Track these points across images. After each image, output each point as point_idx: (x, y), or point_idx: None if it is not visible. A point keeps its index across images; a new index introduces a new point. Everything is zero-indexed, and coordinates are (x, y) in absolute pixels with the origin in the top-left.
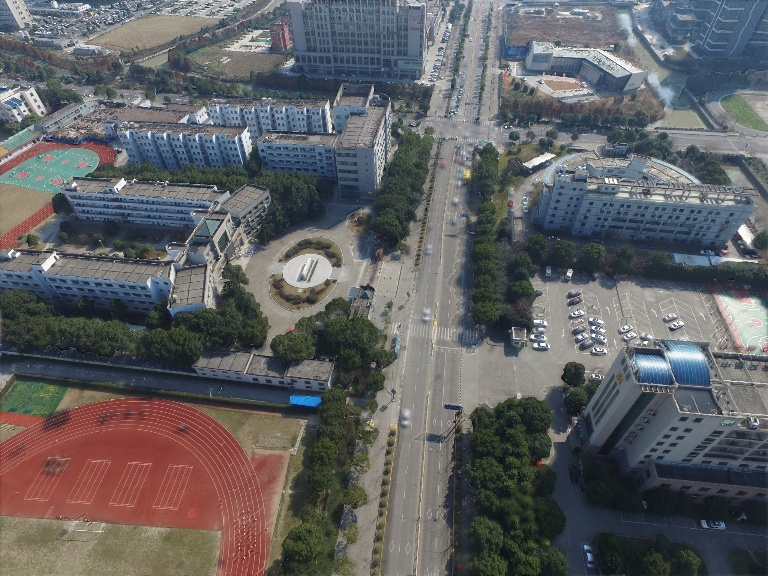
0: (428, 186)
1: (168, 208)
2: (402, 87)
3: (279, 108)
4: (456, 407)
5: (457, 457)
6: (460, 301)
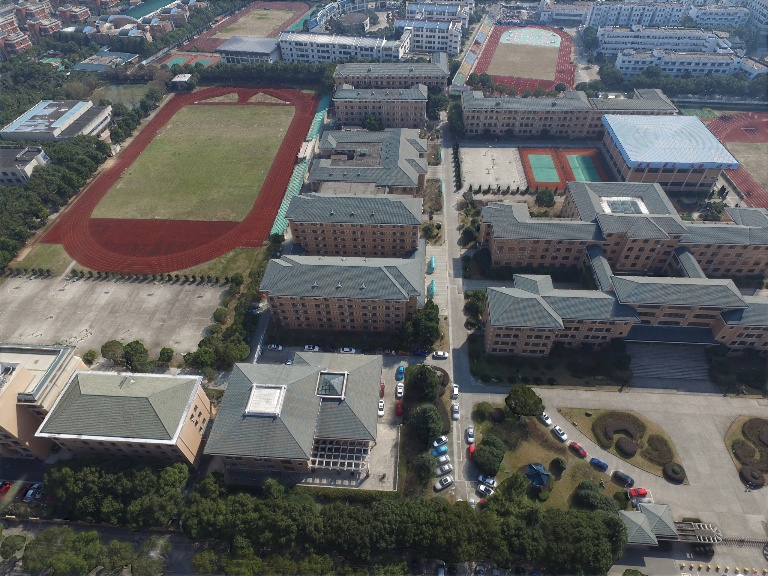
0: None
1: (670, 42)
2: None
3: None
4: None
5: None
6: None
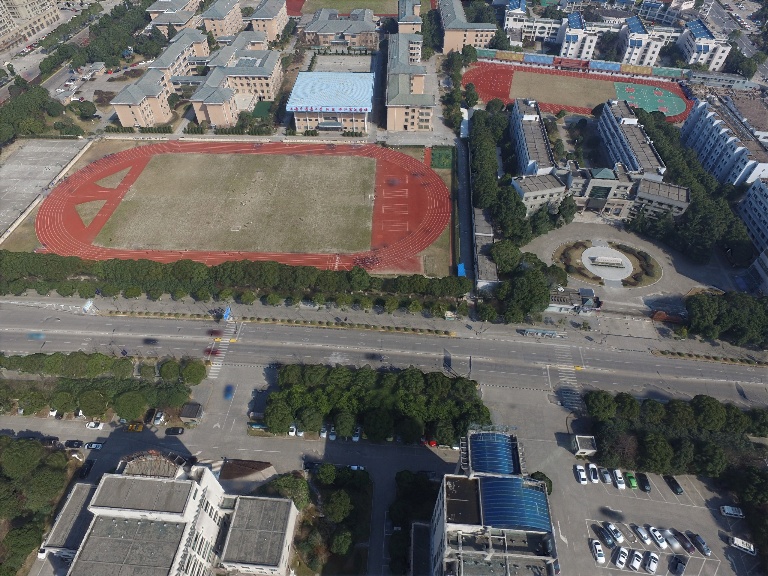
0: None
1: None
2: None
3: None
4: None
5: None
6: None
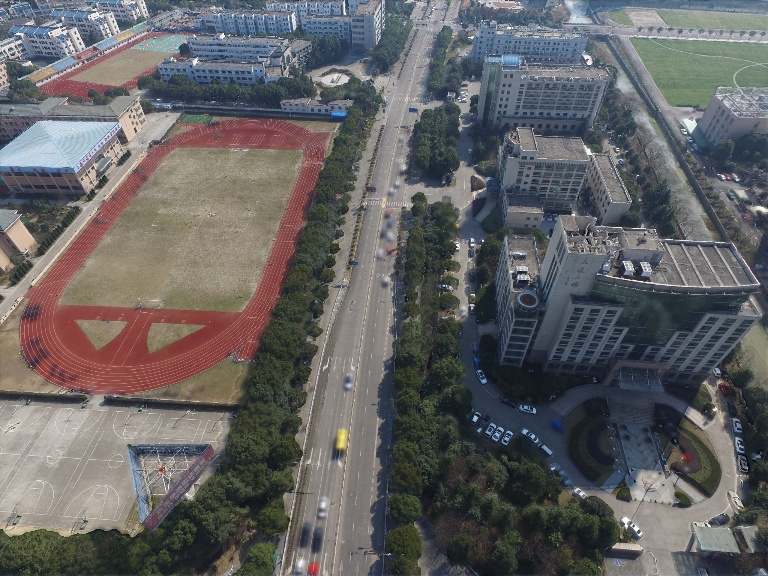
0: (408, 48)
1: (251, 50)
2: (393, 4)
3: (313, 3)
4: (414, 110)
5: (414, 131)
6: (422, 89)
